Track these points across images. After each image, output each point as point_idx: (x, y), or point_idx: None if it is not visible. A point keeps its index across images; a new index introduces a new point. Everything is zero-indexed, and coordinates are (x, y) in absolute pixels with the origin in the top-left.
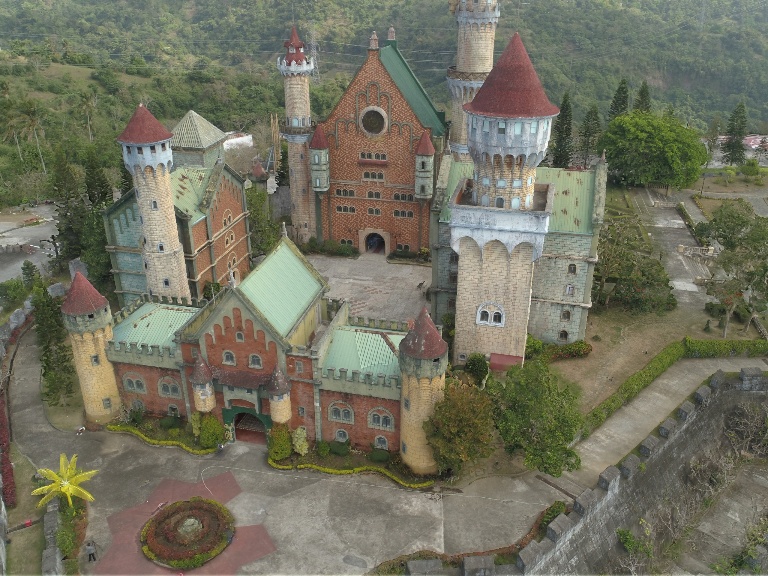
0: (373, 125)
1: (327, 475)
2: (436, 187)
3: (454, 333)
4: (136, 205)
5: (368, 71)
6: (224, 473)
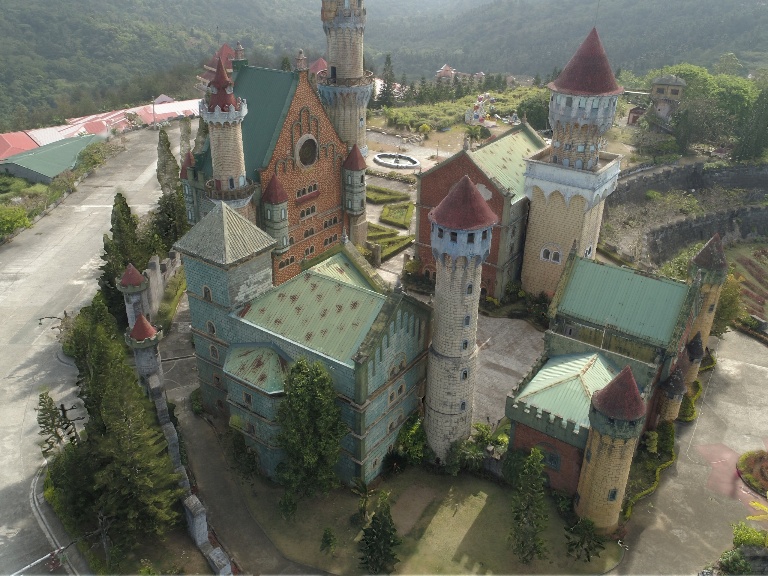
0: (307, 156)
1: (699, 398)
2: (490, 179)
3: (524, 293)
4: (392, 325)
5: (300, 96)
6: (698, 450)
